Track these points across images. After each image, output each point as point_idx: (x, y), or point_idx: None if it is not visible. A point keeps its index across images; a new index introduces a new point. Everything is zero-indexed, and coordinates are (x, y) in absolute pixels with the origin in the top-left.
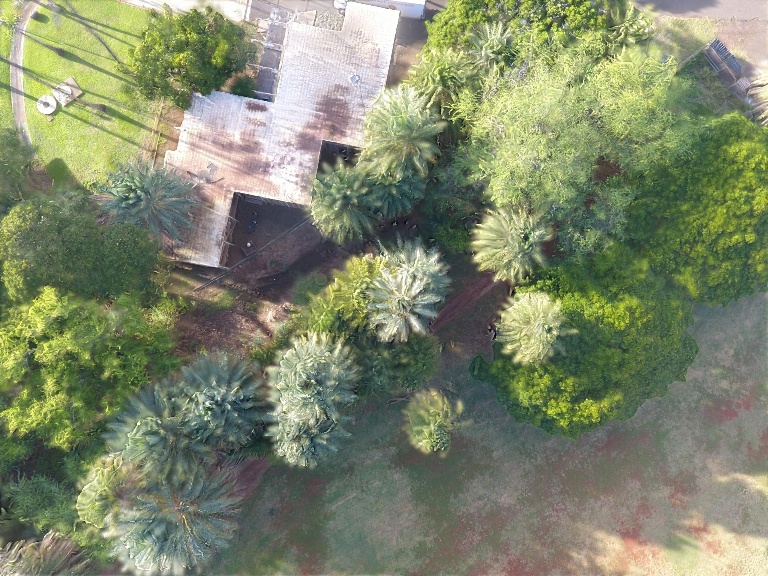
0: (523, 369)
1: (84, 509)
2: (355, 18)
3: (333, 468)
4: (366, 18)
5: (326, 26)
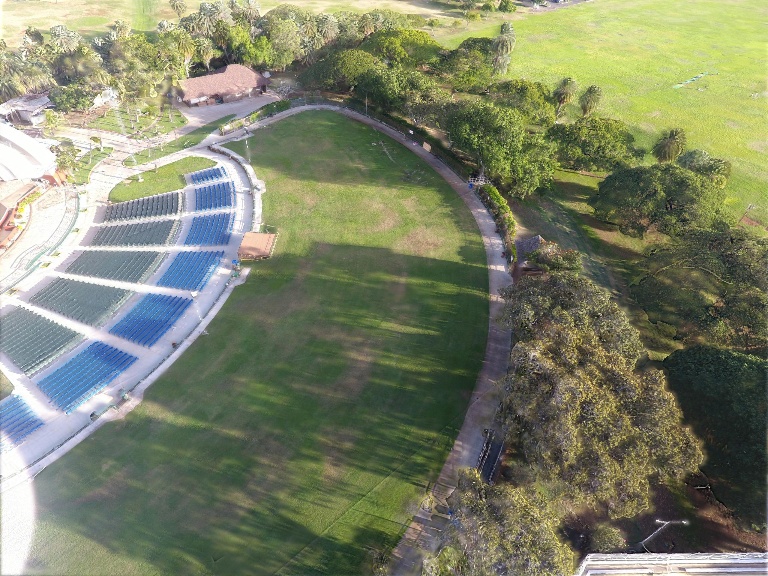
0: (6, 54)
1: (126, 23)
2: (6, 111)
3: (90, 68)
4: (1, 111)
5: (23, 126)
